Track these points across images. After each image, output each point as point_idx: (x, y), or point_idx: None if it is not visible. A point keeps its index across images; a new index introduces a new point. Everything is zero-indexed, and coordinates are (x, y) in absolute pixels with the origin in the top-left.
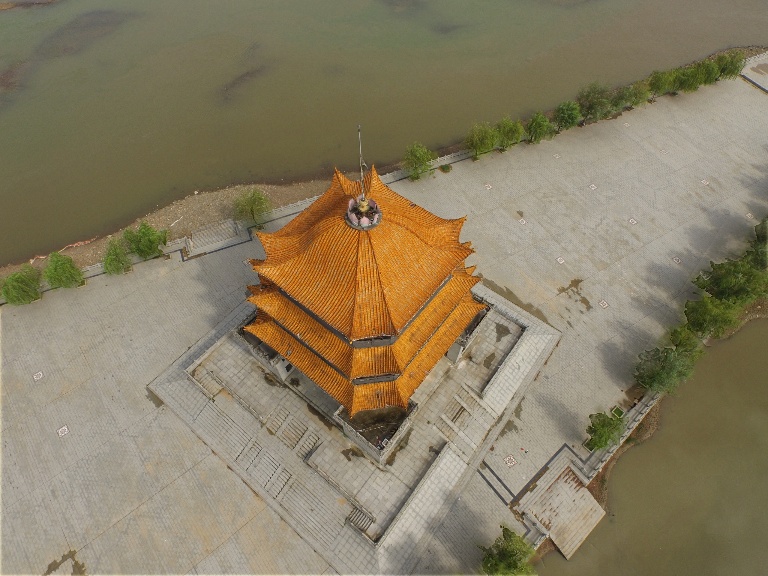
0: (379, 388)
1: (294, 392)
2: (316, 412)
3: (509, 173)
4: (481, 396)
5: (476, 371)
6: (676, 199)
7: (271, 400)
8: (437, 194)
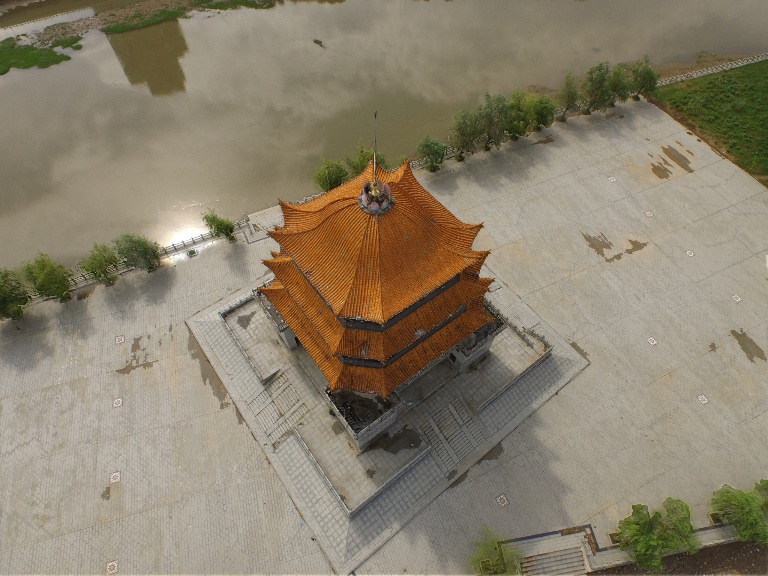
0: None
1: None
2: None
3: None
4: None
5: None
6: None
7: None
8: (200, 572)
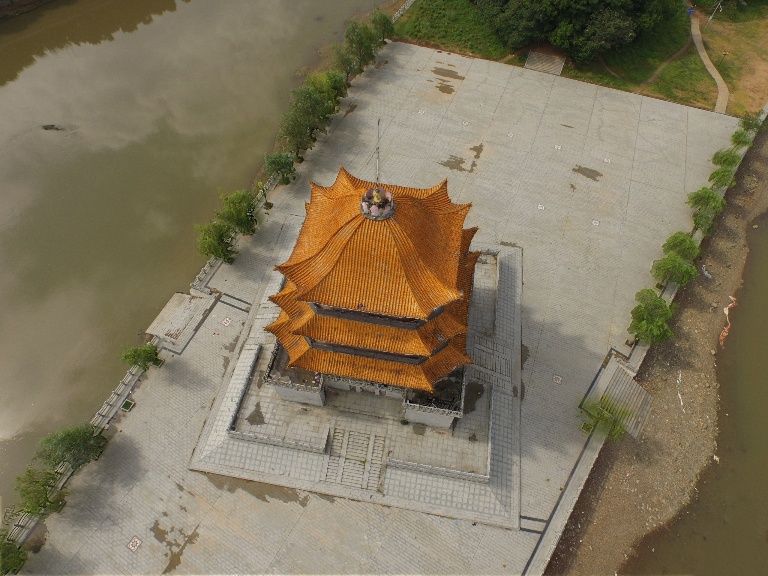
0: None
1: None
2: None
3: None
4: None
5: None
6: None
7: None
8: None
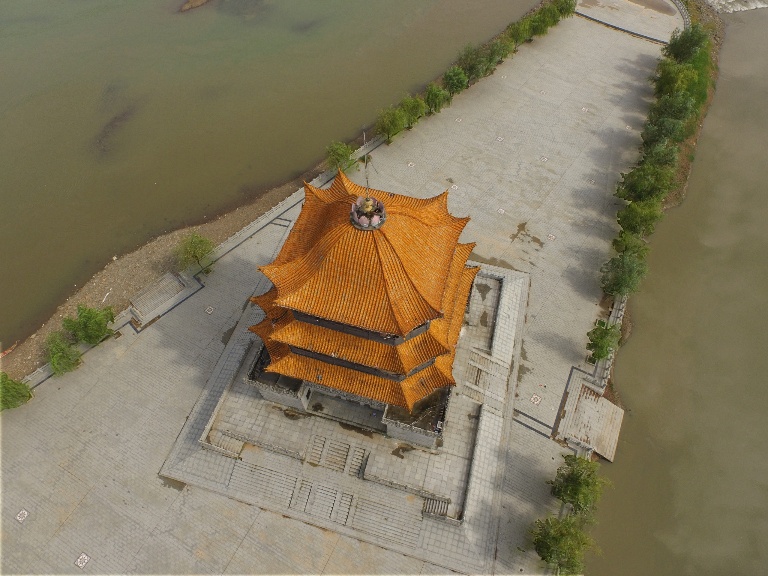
0: (421, 376)
1: (321, 417)
2: (351, 427)
3: (424, 147)
4: (490, 353)
5: (477, 333)
6: (569, 130)
7: (302, 434)
8: None
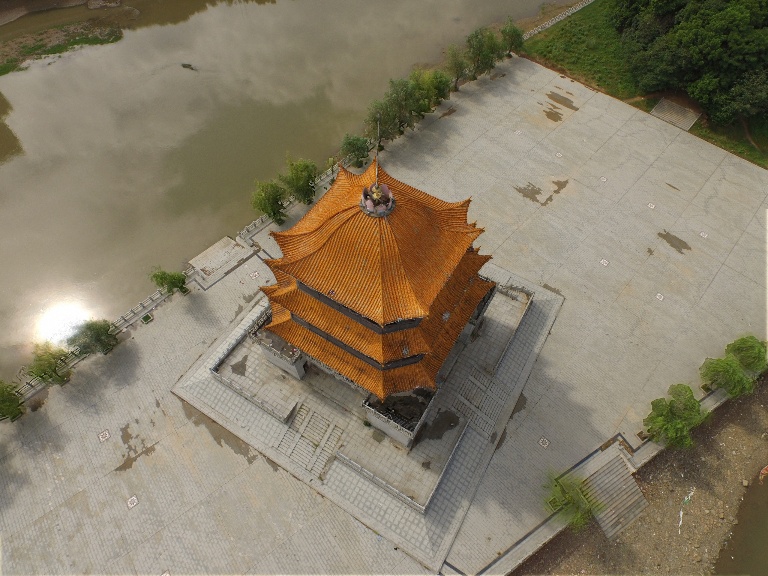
0: None
1: None
2: None
3: None
4: None
5: None
6: None
7: None
8: None
